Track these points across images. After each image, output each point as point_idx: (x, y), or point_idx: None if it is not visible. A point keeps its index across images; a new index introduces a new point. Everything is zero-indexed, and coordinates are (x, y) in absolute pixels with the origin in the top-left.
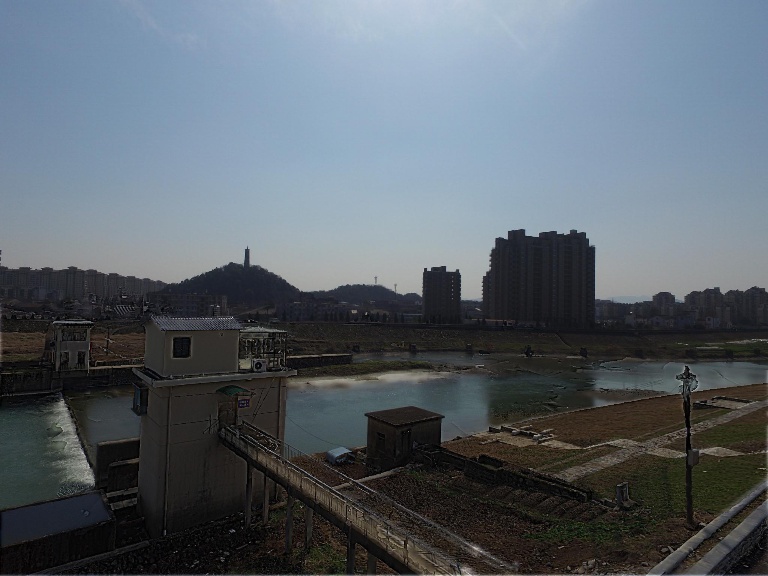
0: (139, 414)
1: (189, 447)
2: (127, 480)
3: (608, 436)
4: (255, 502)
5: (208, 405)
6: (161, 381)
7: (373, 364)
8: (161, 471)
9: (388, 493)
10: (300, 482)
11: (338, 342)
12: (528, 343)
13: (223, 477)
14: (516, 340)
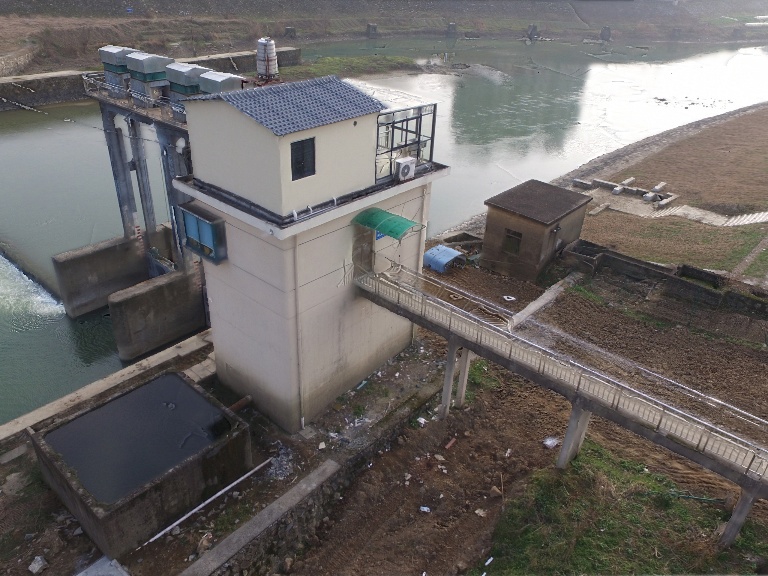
0: (217, 262)
1: (322, 310)
2: (140, 316)
3: (759, 199)
4: (391, 354)
5: (341, 245)
6: (290, 227)
7: (335, 64)
8: (292, 351)
9: (578, 331)
10: (615, 399)
11: (260, 22)
12: (531, 19)
13: (359, 336)
14: (515, 14)
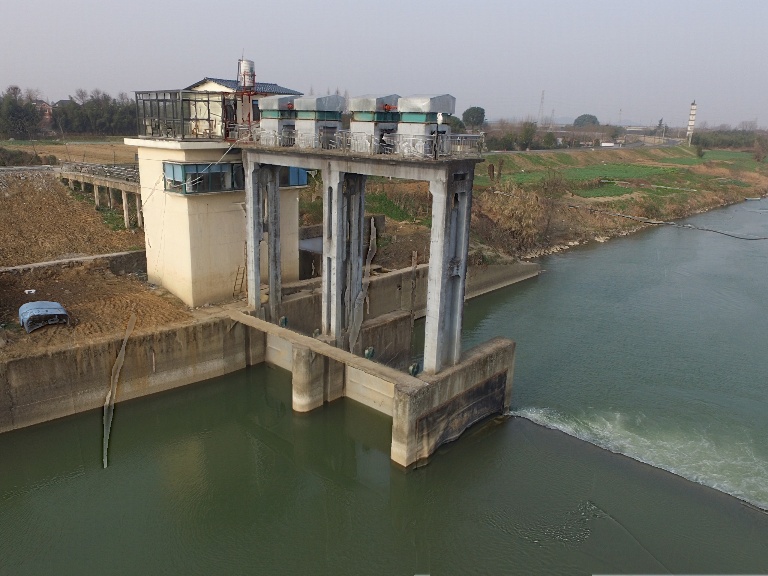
0: None
1: None
2: None
3: None
4: None
5: None
6: None
7: None
8: None
9: None
10: None
11: None
12: None
13: None
14: None
